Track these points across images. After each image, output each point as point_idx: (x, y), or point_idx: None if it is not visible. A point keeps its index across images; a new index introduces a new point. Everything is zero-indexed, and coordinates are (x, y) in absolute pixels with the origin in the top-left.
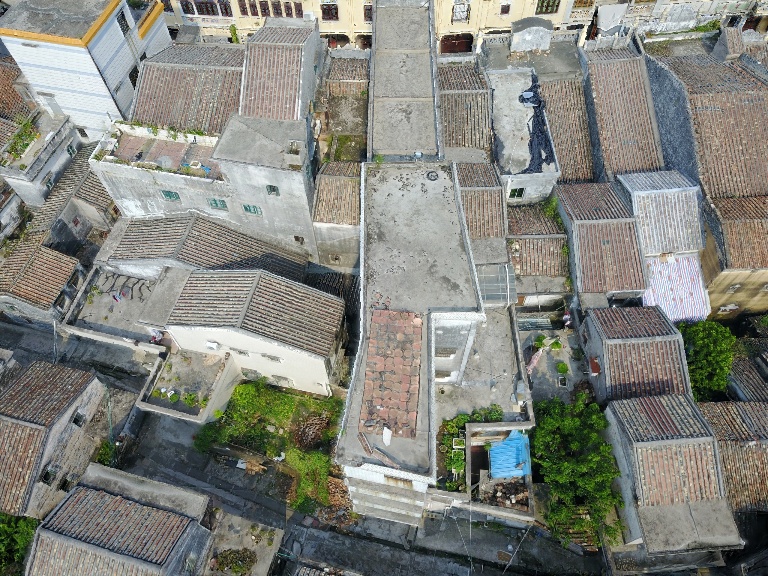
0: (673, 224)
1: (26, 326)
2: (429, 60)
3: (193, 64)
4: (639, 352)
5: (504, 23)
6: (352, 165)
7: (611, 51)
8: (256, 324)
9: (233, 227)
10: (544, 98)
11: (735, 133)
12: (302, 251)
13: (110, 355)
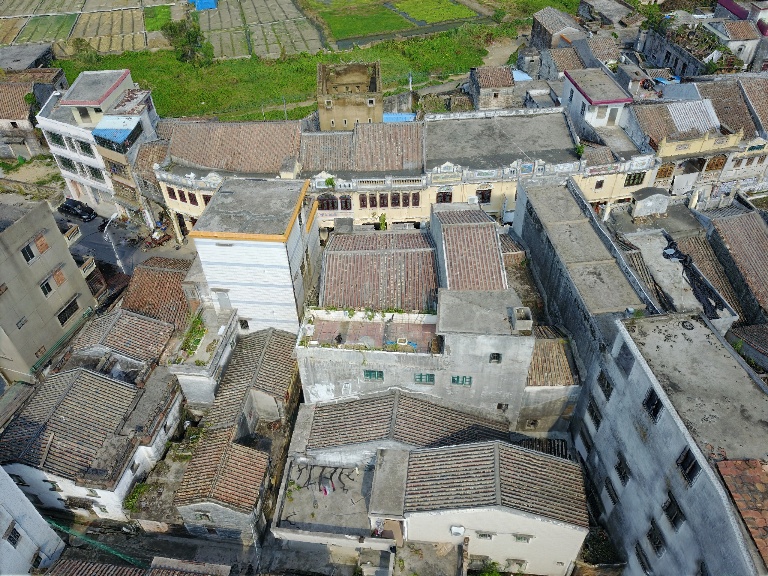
0: None
1: (200, 538)
2: (591, 228)
3: (374, 249)
4: None
5: (597, 196)
6: (541, 328)
7: (722, 209)
8: (514, 499)
9: (434, 401)
10: None
11: None
12: (503, 419)
13: (303, 560)
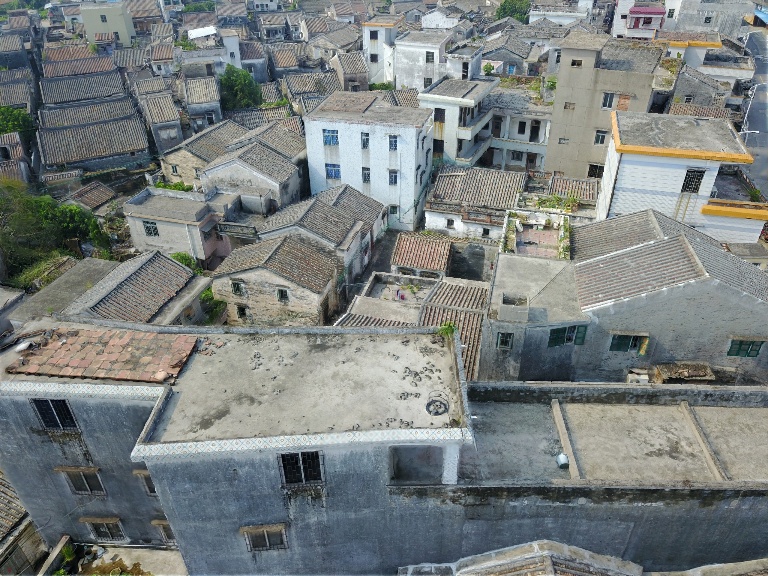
0: None
1: None
2: None
3: None
4: None
5: None
6: None
7: None
8: None
9: None
10: None
11: None
12: None
13: None
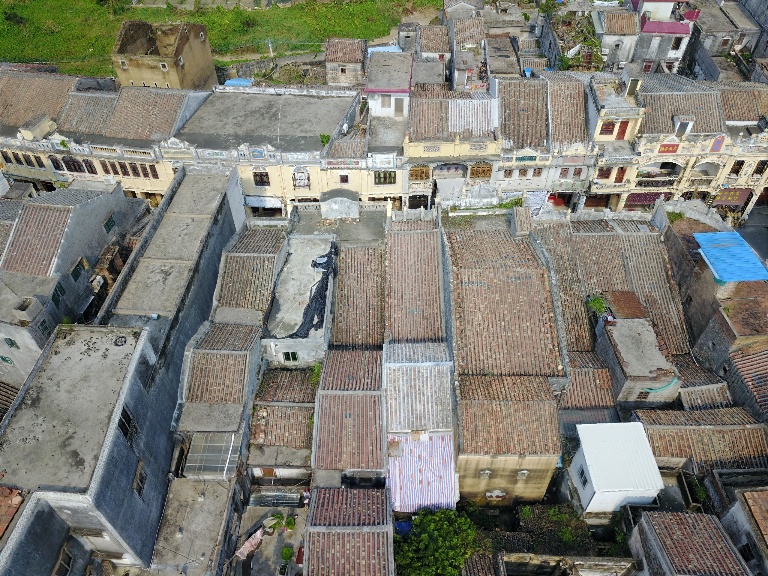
0: (423, 400)
1: None
2: None
3: None
4: (344, 543)
5: None
6: None
7: (416, 222)
8: None
9: None
10: (346, 263)
11: (499, 309)
12: None
13: None
